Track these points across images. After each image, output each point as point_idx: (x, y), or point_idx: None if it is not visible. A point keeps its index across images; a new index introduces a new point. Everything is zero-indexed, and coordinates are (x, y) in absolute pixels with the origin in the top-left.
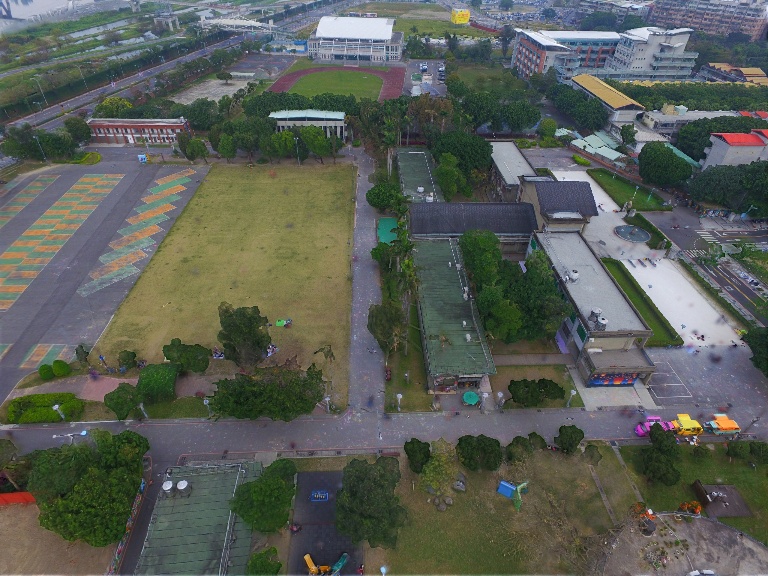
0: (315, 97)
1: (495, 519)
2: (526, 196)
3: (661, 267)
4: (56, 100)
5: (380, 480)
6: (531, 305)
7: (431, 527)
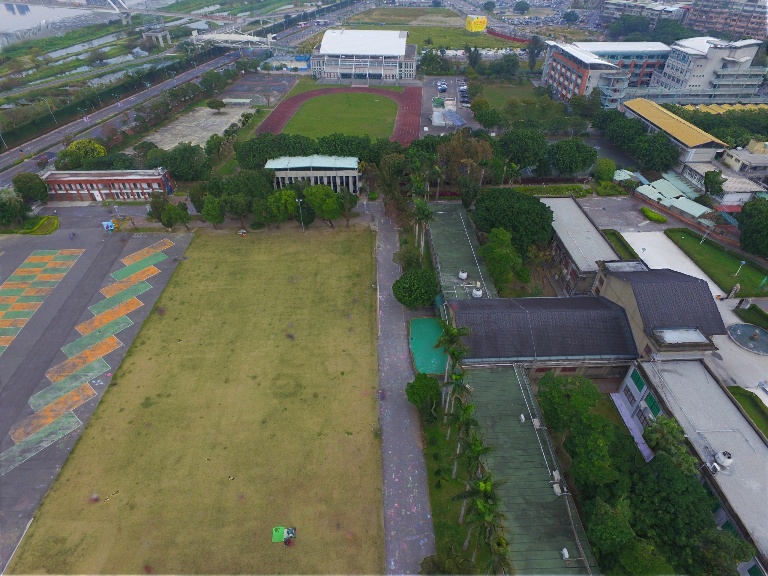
0: (321, 139)
1: None
2: (611, 292)
3: None
4: (18, 141)
5: None
6: (681, 543)
7: None
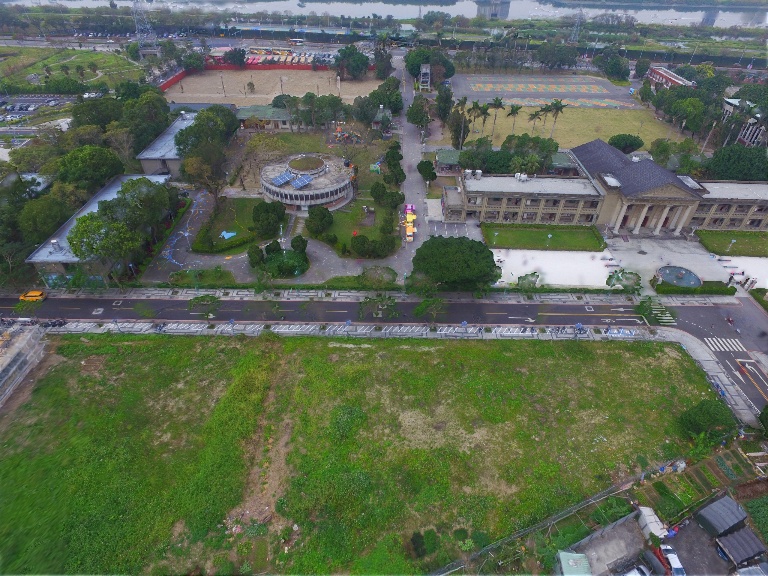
0: None
1: None
2: None
3: None
4: None
5: (362, 100)
6: None
7: None
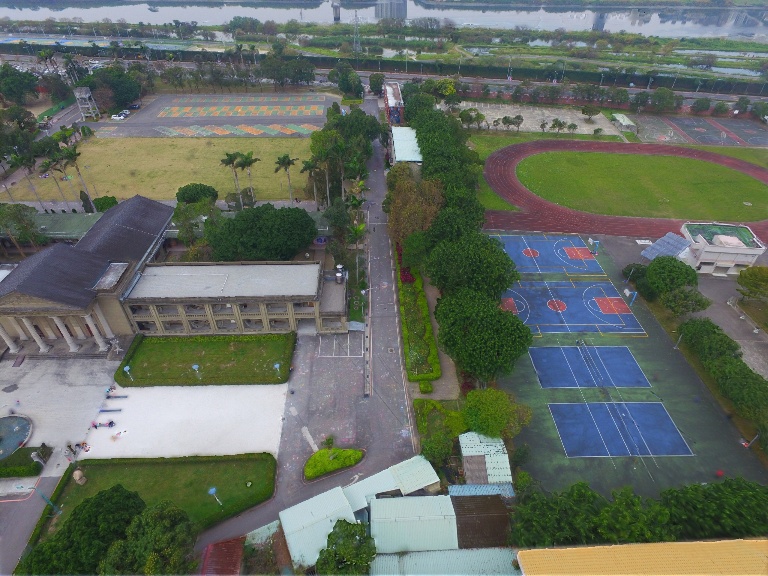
0: None
1: None
2: None
3: None
4: (469, 74)
5: None
6: None
7: None
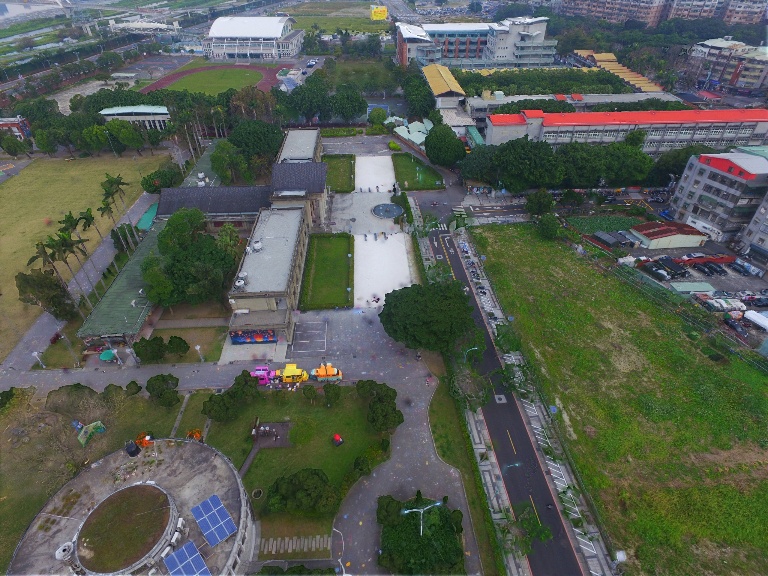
0: (148, 93)
1: None
2: None
3: (391, 240)
4: None
5: None
6: None
7: None
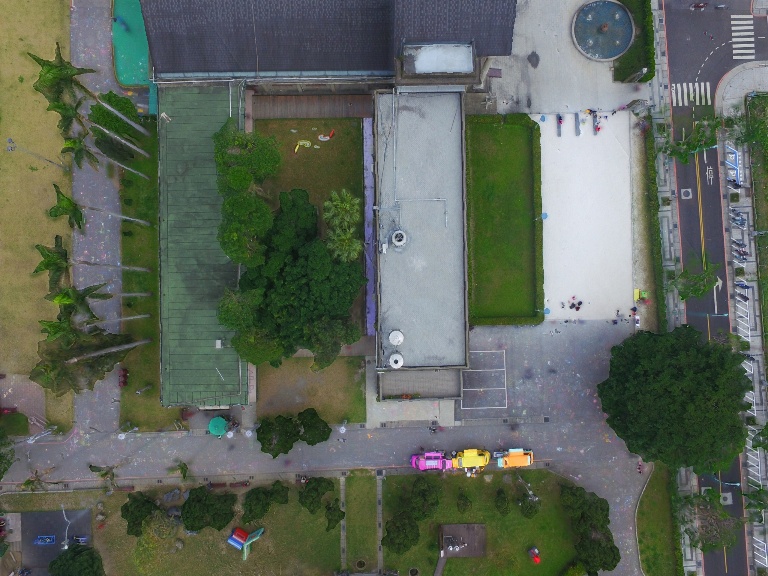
0: None
1: (224, 560)
2: None
3: (606, 134)
4: None
5: None
6: None
7: (159, 568)
